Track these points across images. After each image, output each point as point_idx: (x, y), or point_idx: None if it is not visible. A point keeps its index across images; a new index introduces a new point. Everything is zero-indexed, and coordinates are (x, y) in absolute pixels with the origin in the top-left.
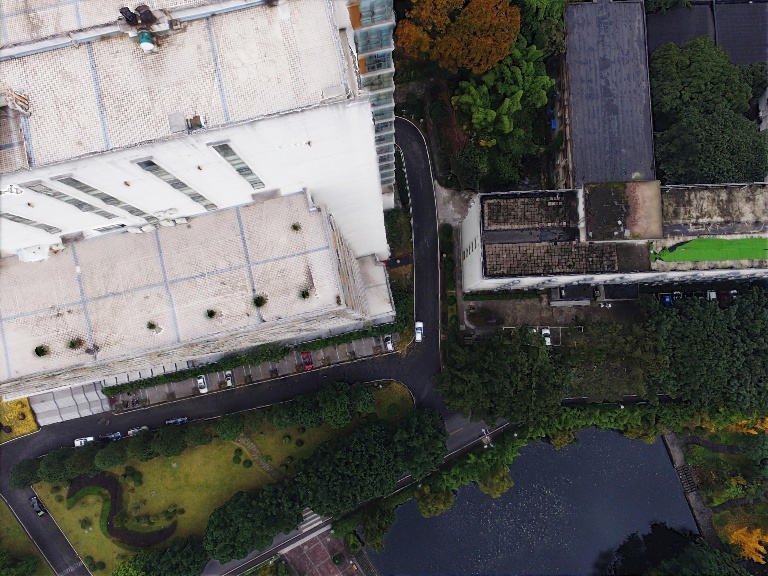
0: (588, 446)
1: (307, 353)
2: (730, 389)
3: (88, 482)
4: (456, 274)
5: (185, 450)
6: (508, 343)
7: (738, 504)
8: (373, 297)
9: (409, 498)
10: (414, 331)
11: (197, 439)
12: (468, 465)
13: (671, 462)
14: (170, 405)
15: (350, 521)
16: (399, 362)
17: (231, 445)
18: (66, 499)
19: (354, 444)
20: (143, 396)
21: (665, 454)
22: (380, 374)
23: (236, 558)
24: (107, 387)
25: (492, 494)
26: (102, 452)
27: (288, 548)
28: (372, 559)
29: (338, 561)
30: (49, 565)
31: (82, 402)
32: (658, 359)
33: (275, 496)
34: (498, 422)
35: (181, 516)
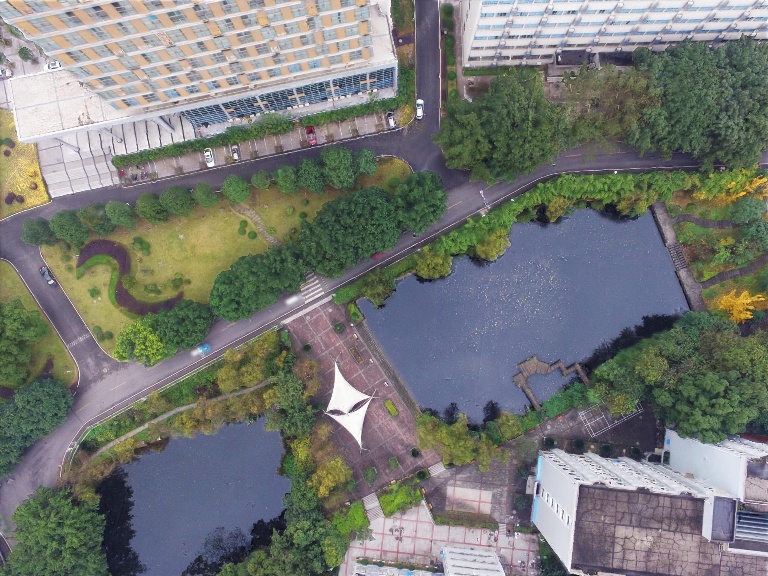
0: (583, 226)
1: (311, 127)
2: (719, 122)
3: (97, 251)
4: (456, 51)
5: (192, 222)
6: (506, 75)
7: (727, 277)
8: (376, 46)
9: (409, 273)
10: (415, 108)
11: (204, 193)
12: (466, 231)
13: (663, 242)
14: (178, 178)
15: (351, 286)
16: (400, 139)
17: (237, 217)
18: (76, 268)
19: (356, 197)
20: (152, 170)
21: (657, 234)
22: (382, 150)
23: (241, 316)
24: (117, 155)
25: (489, 252)
26: (112, 201)
27: (291, 318)
28: (372, 331)
29: (339, 328)
30: (58, 335)
31: (92, 174)
32: (650, 92)
33: (279, 255)
34: (496, 195)
35: (187, 287)
